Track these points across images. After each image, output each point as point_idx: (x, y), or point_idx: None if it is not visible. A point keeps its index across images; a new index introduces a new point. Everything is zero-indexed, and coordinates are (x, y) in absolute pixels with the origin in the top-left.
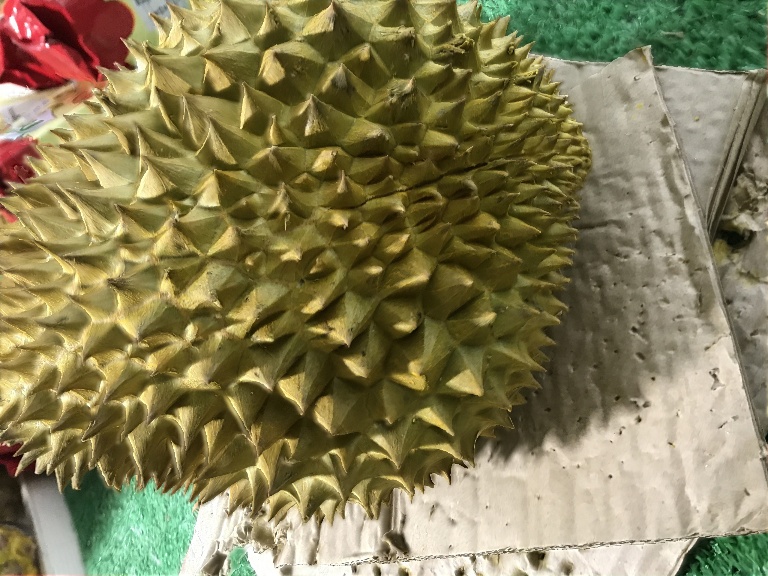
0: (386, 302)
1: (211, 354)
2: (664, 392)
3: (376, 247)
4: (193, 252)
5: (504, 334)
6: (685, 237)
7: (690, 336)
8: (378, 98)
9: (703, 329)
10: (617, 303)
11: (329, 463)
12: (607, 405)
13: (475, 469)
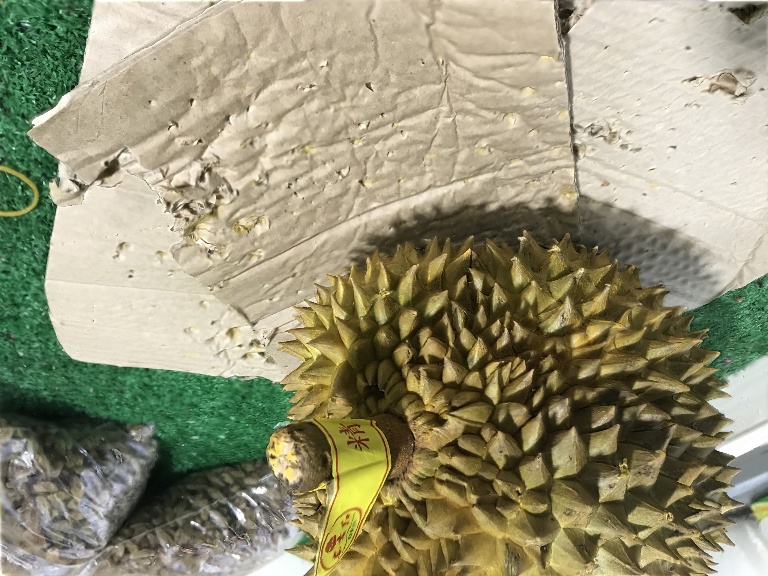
0: None
1: None
2: None
3: None
4: None
5: None
6: None
7: None
8: None
9: None
10: None
11: None
12: None
13: None
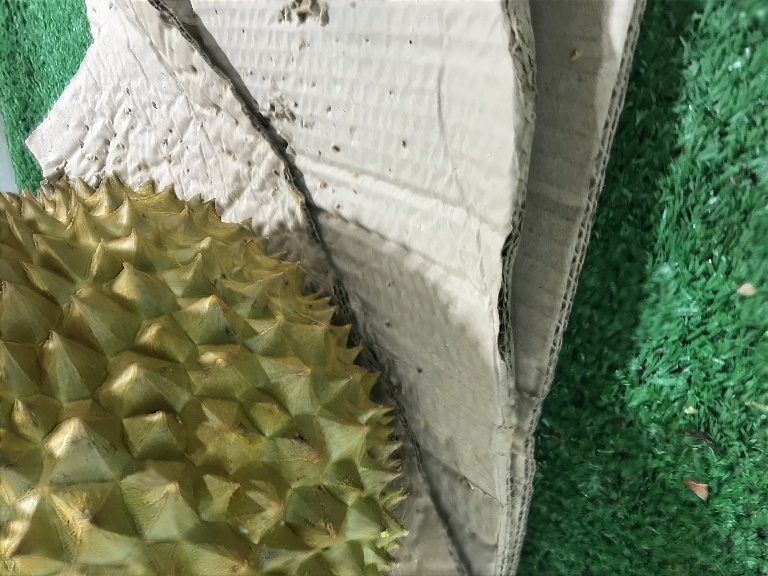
0: None
1: None
2: None
3: None
4: None
5: None
6: None
7: None
8: None
9: None
10: None
11: None
12: None
13: None
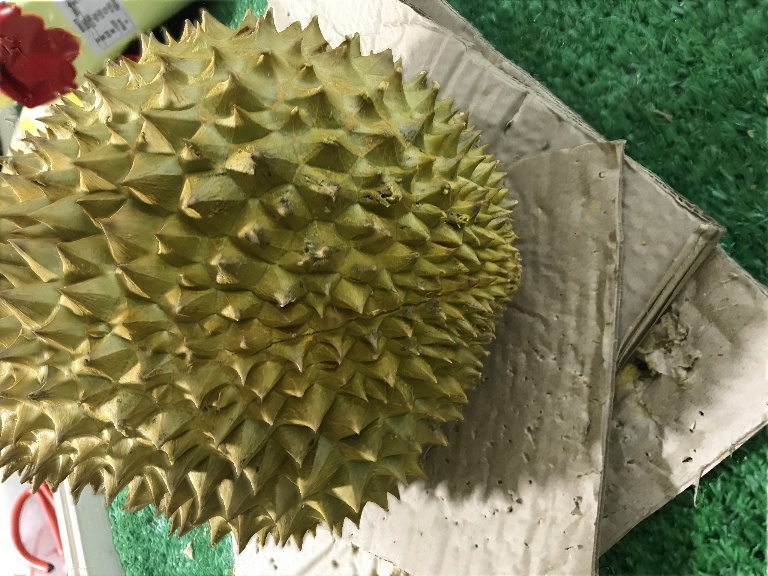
0: (283, 427)
1: (123, 456)
2: (535, 498)
3: (277, 384)
4: (106, 377)
5: (391, 455)
6: (595, 364)
7: (570, 459)
8: (295, 245)
9: (582, 456)
10: (522, 398)
11: None
12: (491, 484)
13: None
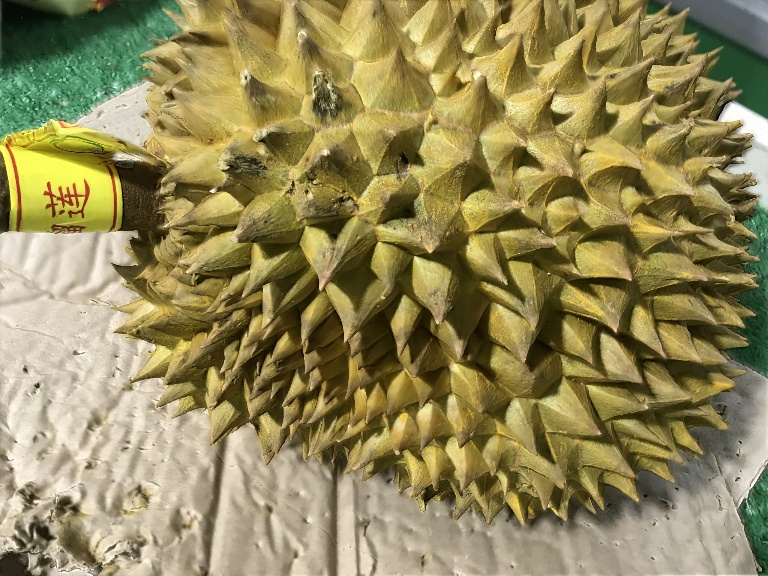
0: None
1: (687, 255)
2: (688, 501)
3: None
4: None
5: None
6: None
7: (697, 467)
8: None
9: (703, 466)
10: None
11: (610, 432)
12: None
13: (487, 526)
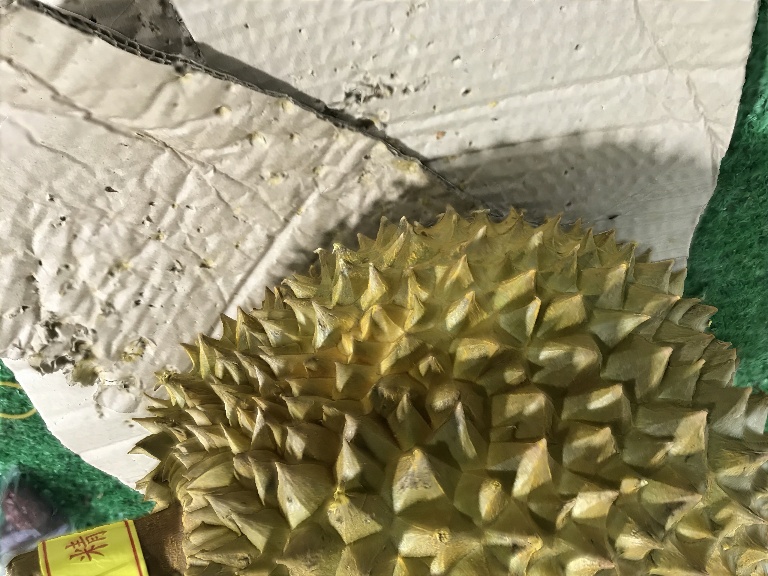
0: None
1: None
2: None
3: None
4: None
5: None
6: None
7: None
8: None
9: None
10: None
11: None
12: None
13: None
